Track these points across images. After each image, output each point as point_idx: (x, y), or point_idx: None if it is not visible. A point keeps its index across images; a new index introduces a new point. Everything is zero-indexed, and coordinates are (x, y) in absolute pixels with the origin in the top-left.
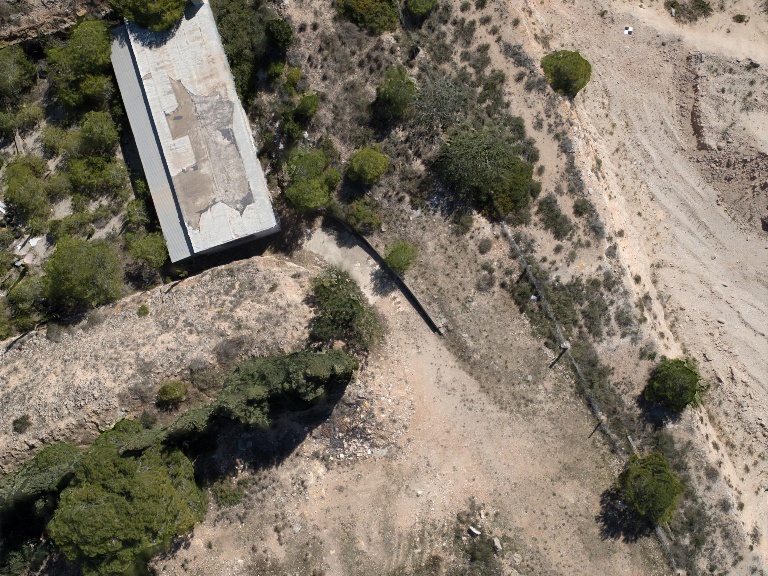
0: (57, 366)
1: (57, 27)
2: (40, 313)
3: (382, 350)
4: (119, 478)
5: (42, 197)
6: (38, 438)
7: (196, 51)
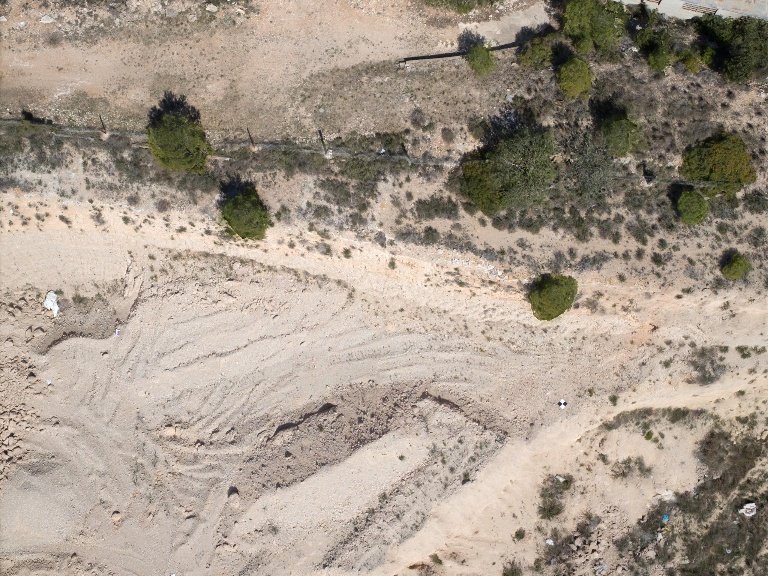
0: None
1: None
2: None
3: (416, 8)
4: None
5: None
6: None
7: None
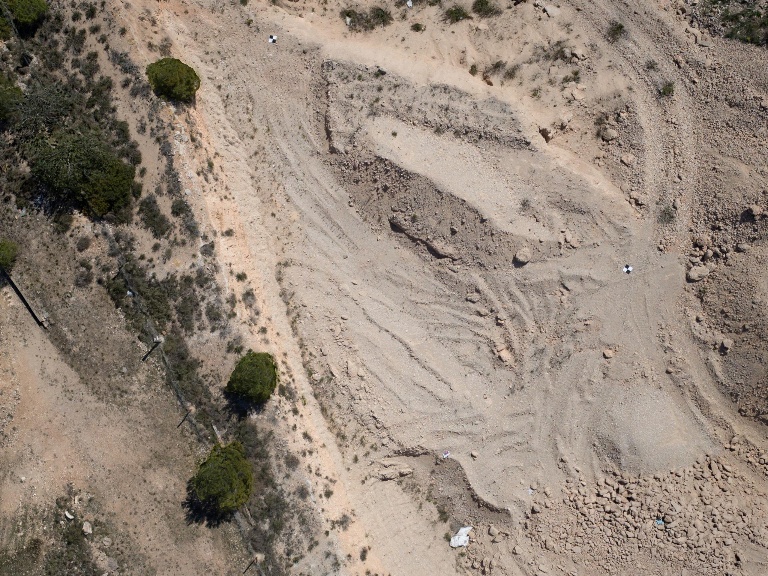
0: None
1: None
2: None
3: None
4: None
5: None
6: None
7: None
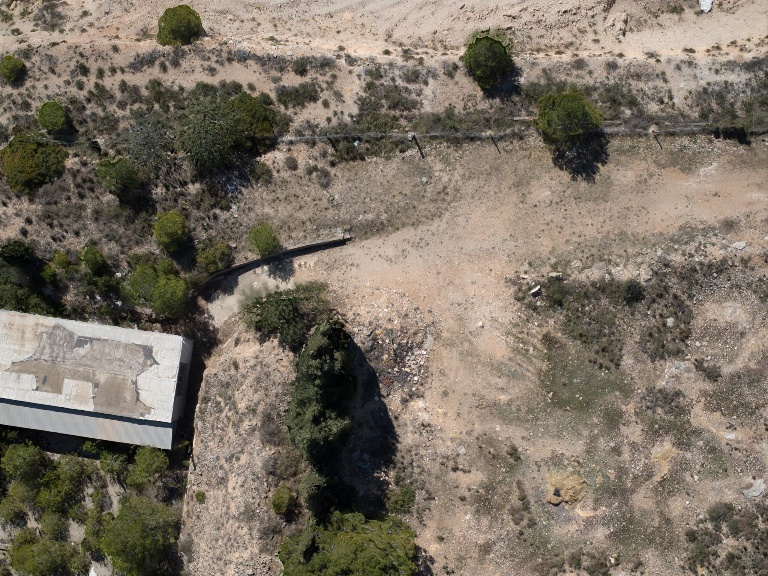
0: None
1: None
2: None
3: (339, 297)
4: (325, 574)
5: (55, 545)
6: None
7: None
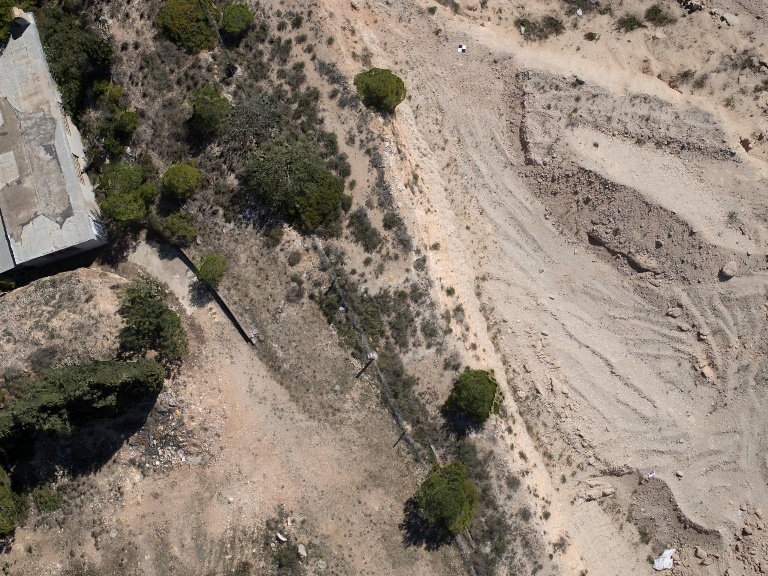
0: None
1: None
2: None
3: (196, 360)
4: None
5: None
6: None
7: (22, 69)
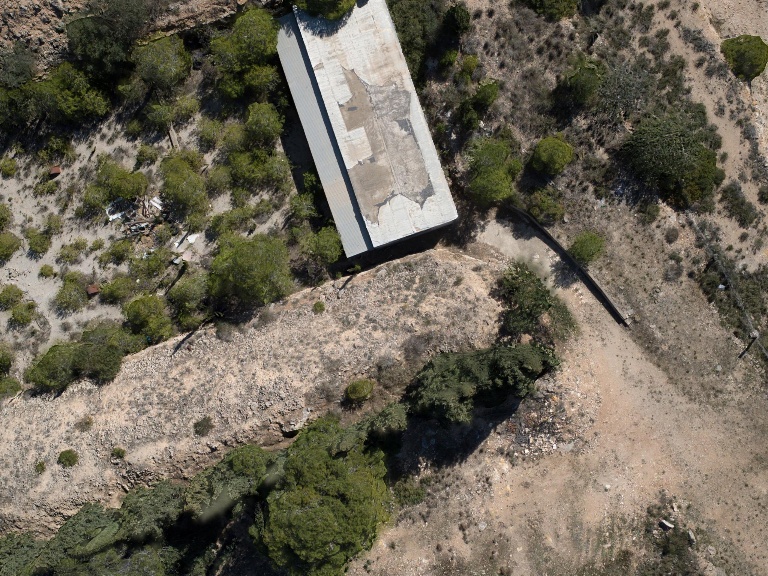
0: (233, 366)
1: (216, 16)
2: (201, 312)
3: (567, 343)
4: (331, 480)
5: (203, 192)
6: (221, 441)
7: (369, 40)
